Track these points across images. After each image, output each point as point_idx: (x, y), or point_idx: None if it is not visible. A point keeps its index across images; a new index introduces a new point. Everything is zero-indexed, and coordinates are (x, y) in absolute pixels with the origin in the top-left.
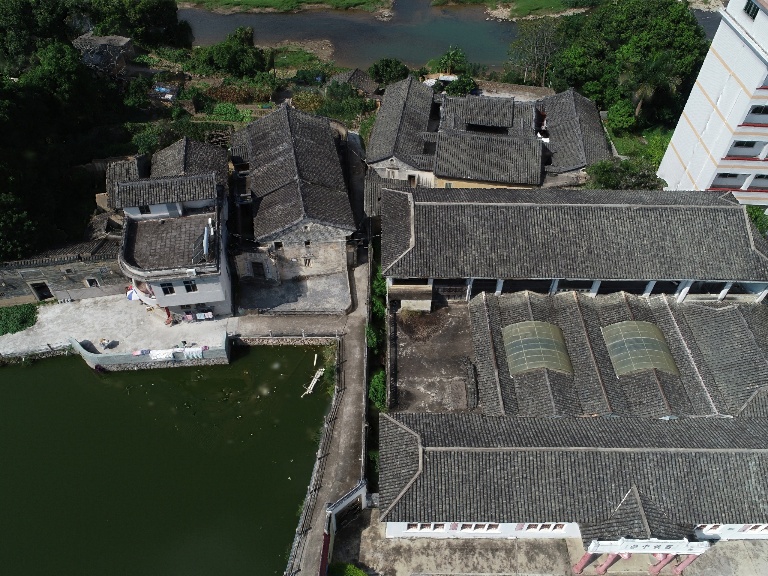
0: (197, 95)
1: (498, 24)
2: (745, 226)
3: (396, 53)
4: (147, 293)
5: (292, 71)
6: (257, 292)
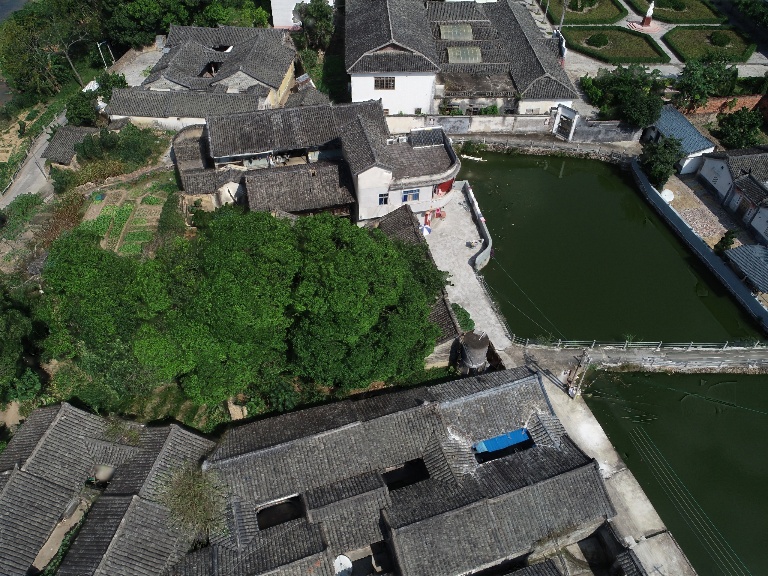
0: None
1: None
2: None
3: None
4: None
5: None
6: None
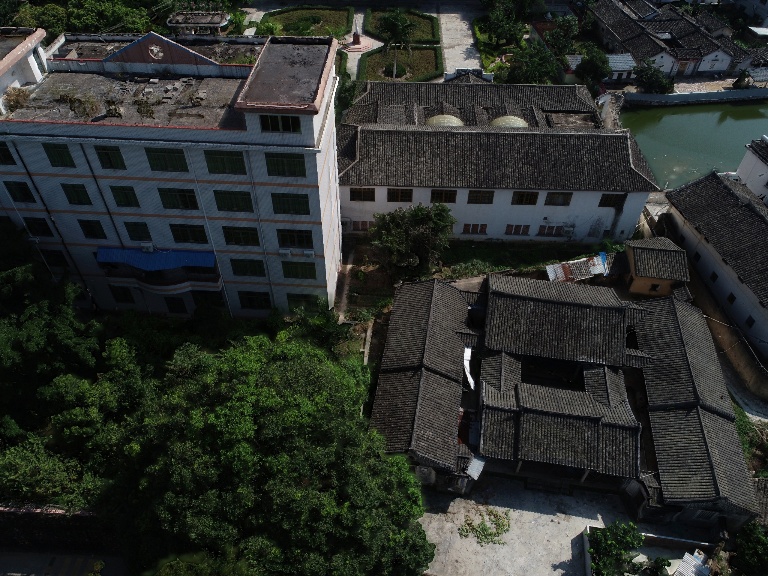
0: None
1: None
2: None
3: None
4: None
5: None
6: None
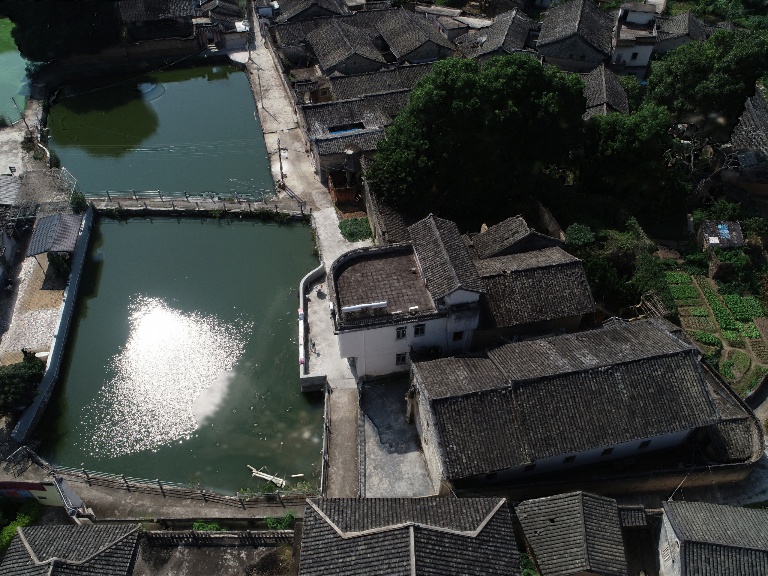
0: (742, 267)
1: None
2: None
3: None
4: None
5: None
6: (395, 400)
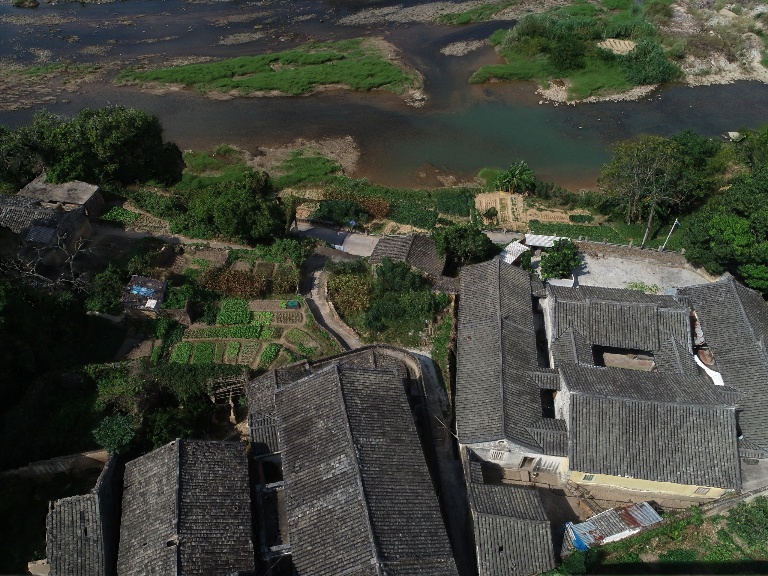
0: (193, 295)
1: (555, 109)
2: None
3: (437, 156)
4: None
5: (311, 192)
6: None
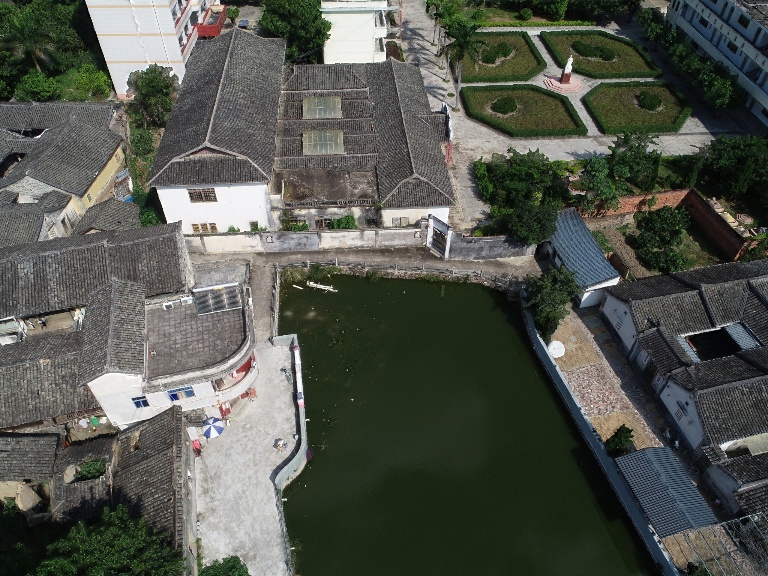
0: None
1: None
2: (249, 34)
3: None
4: (245, 375)
5: None
6: None
